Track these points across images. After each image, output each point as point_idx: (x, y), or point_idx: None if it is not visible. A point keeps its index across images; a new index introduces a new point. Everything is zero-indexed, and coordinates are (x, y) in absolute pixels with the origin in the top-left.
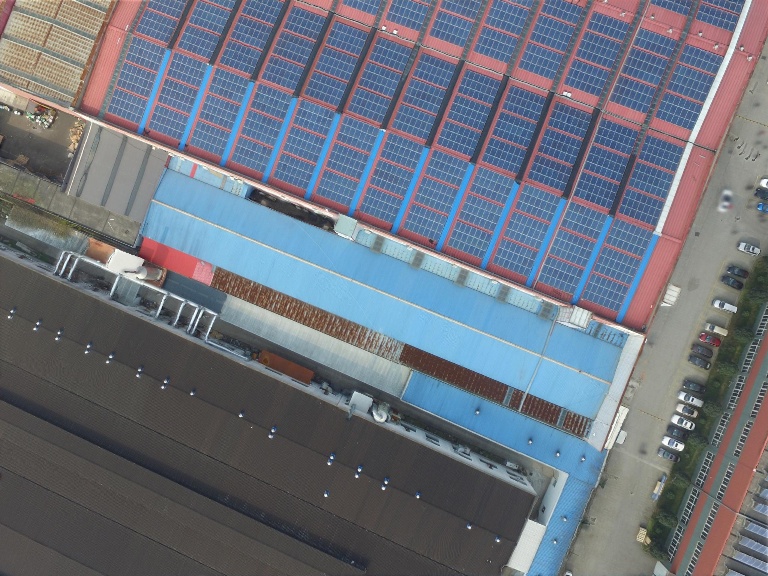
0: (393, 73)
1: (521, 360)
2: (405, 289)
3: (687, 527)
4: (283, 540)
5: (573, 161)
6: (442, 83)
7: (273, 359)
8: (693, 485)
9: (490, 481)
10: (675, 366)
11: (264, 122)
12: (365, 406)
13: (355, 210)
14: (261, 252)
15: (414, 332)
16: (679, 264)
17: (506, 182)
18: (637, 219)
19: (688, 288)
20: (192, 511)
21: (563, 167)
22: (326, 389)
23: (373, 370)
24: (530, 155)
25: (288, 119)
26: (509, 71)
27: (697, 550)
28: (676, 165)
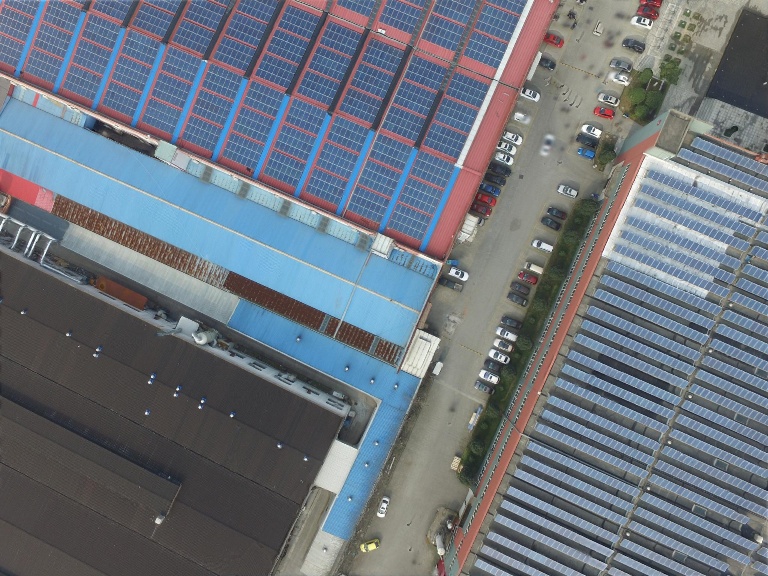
0: (218, 7)
1: (337, 289)
2: (230, 218)
3: (492, 454)
4: (103, 454)
5: (383, 95)
6: (264, 17)
7: (109, 285)
8: (505, 416)
9: (302, 403)
10: (495, 303)
11: (94, 51)
12: (191, 330)
13: (178, 138)
14: (95, 179)
15: (235, 259)
16: (503, 205)
17: (319, 113)
18: (440, 152)
19: (510, 228)
20: (17, 424)
21: (373, 100)
22: (160, 315)
23: (205, 298)
24: (343, 88)
25: (117, 48)
26: (328, 8)
27: (493, 473)
28: (481, 101)
